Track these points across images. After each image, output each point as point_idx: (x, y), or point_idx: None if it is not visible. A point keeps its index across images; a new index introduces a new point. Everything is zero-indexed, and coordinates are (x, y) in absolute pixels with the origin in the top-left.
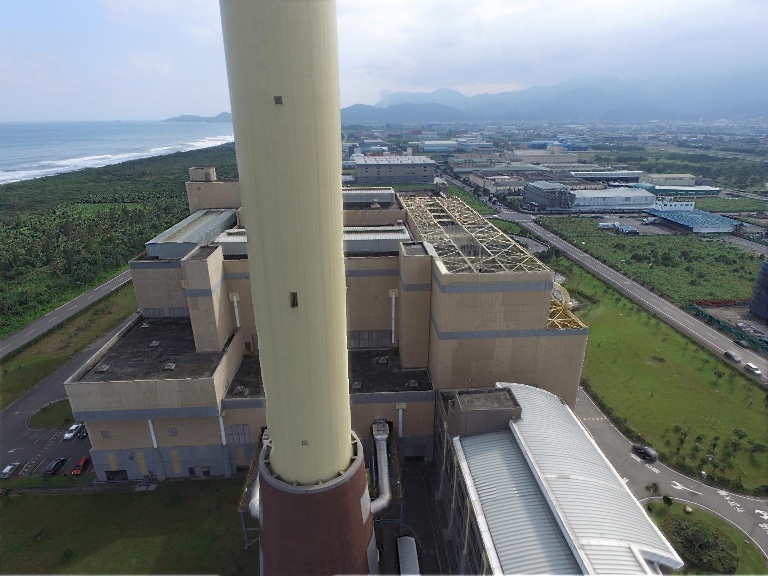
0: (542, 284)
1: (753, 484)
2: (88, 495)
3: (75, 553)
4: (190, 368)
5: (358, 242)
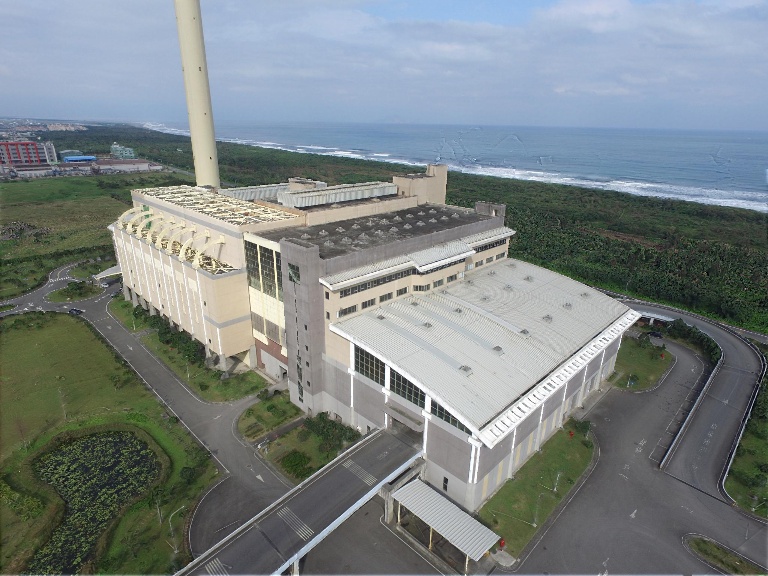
0: None
1: (16, 317)
2: None
3: None
4: None
5: None
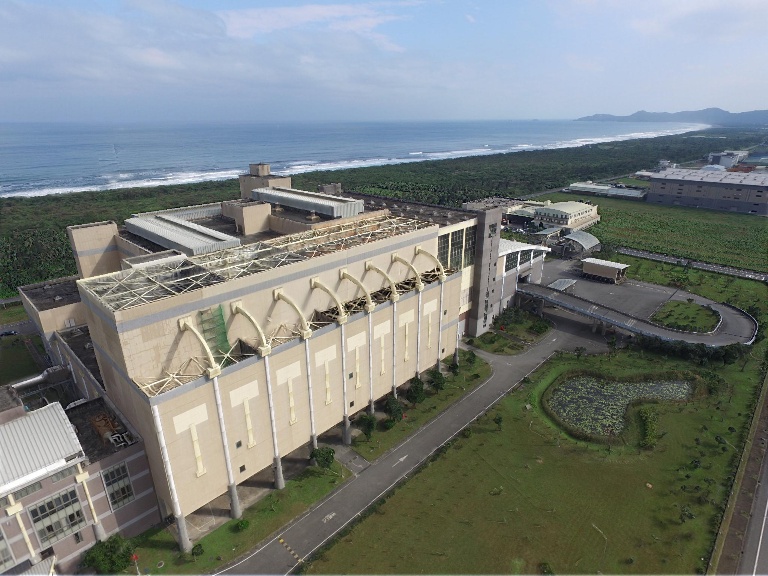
0: (112, 323)
1: None
2: (33, 361)
3: None
4: (60, 303)
5: (171, 242)
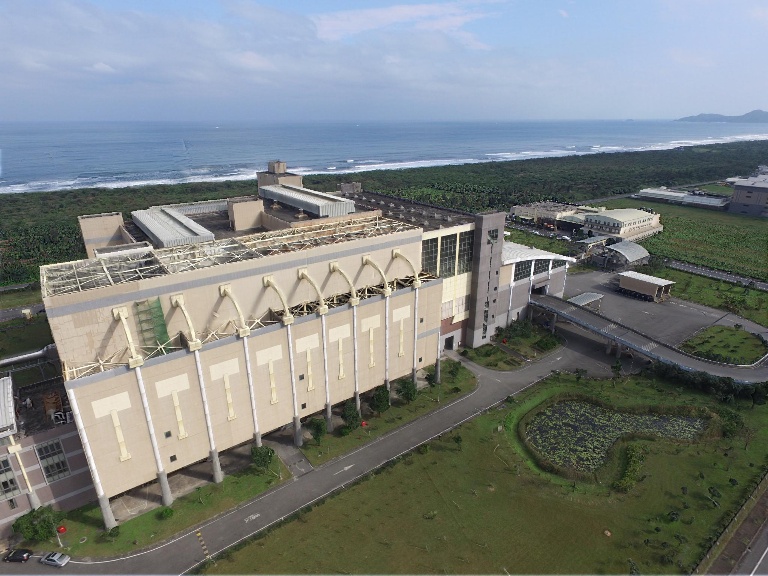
0: None
1: None
2: None
3: (5, 353)
4: None
5: (153, 235)
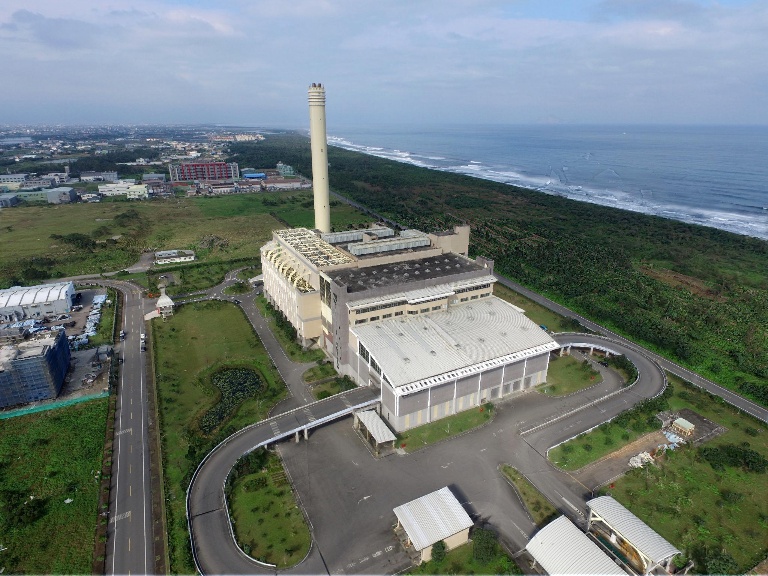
0: None
1: None
2: None
3: None
4: None
5: None
